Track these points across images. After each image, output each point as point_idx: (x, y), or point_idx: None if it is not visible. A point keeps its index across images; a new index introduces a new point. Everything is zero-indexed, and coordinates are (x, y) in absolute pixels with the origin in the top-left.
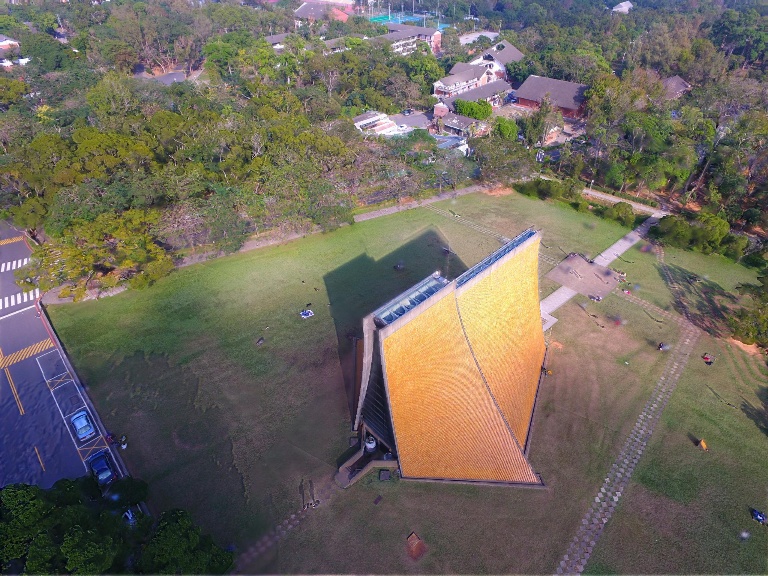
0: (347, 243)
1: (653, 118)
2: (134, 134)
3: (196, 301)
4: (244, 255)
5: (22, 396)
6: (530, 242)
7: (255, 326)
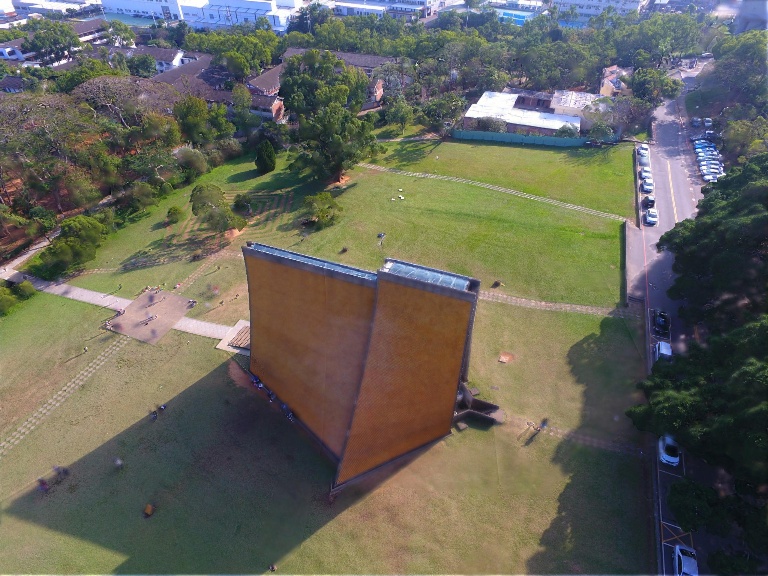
0: None
1: None
2: None
3: None
4: None
5: None
6: None
7: None
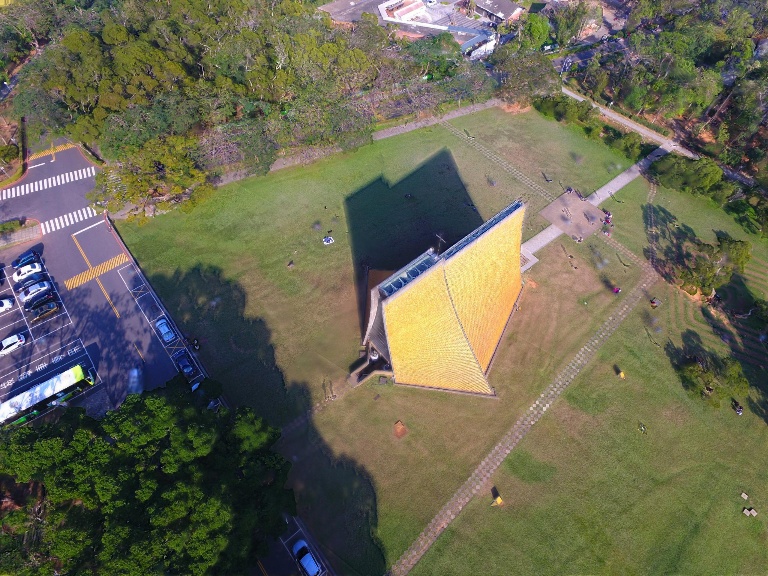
0: (365, 166)
1: (687, 40)
2: (161, 36)
3: (235, 222)
4: (273, 175)
5: (115, 303)
6: (515, 213)
7: (286, 250)
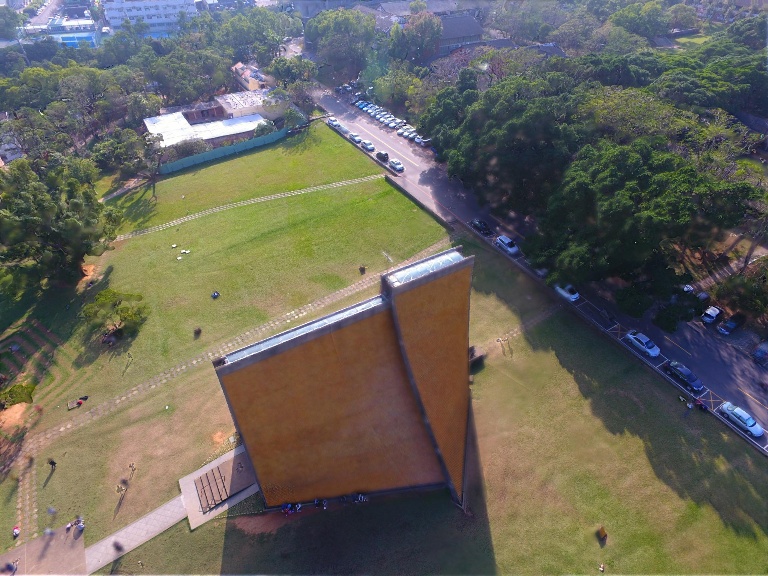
0: None
1: None
2: None
3: None
4: None
5: None
6: None
7: None
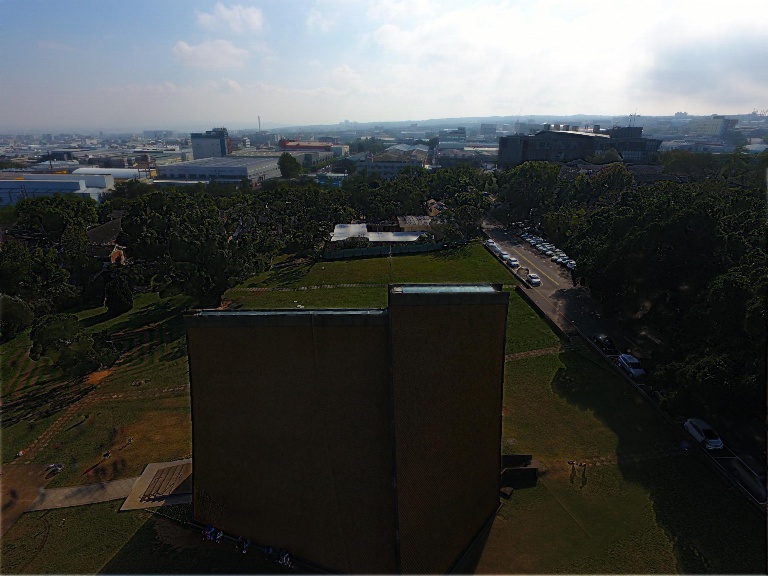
0: None
1: None
2: None
3: None
4: None
5: None
6: None
7: None
